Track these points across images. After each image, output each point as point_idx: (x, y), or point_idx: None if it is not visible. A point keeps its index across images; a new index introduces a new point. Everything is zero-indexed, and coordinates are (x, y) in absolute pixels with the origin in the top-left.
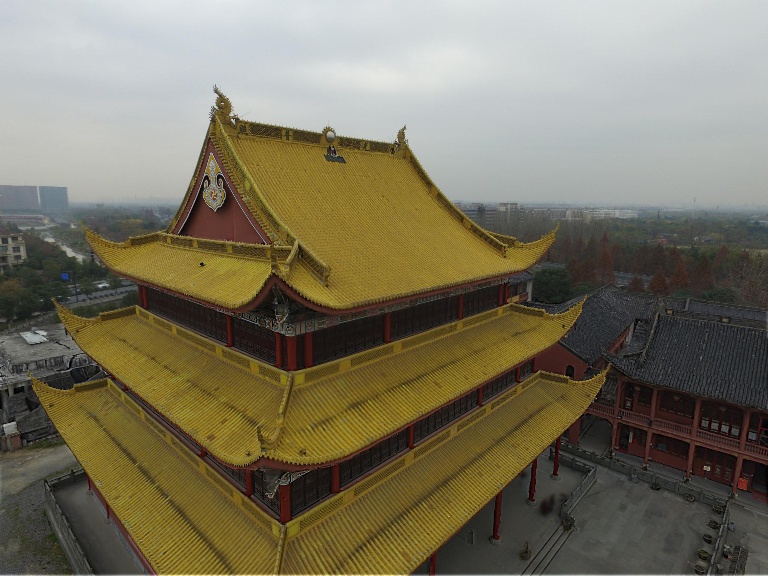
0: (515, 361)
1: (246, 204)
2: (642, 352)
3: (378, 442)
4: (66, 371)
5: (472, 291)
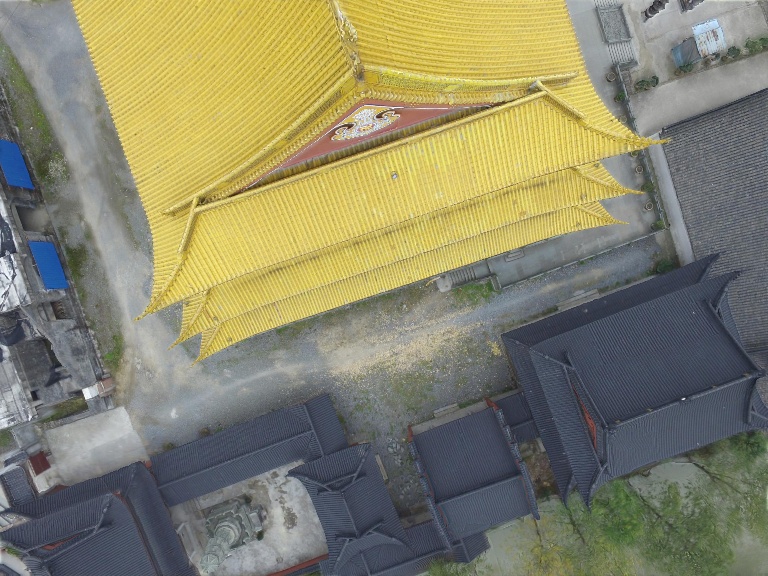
0: None
1: (457, 103)
2: None
3: None
4: (7, 351)
5: None
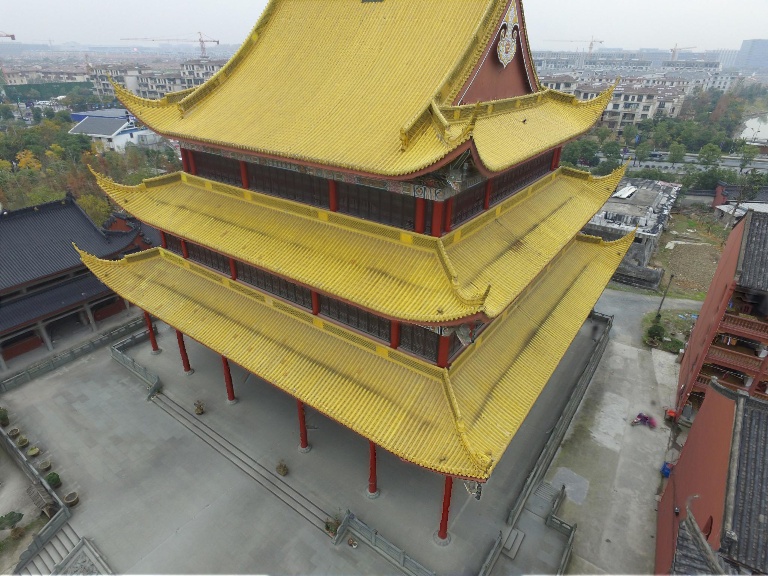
0: (301, 277)
1: None
2: None
3: (161, 230)
4: None
5: (346, 182)
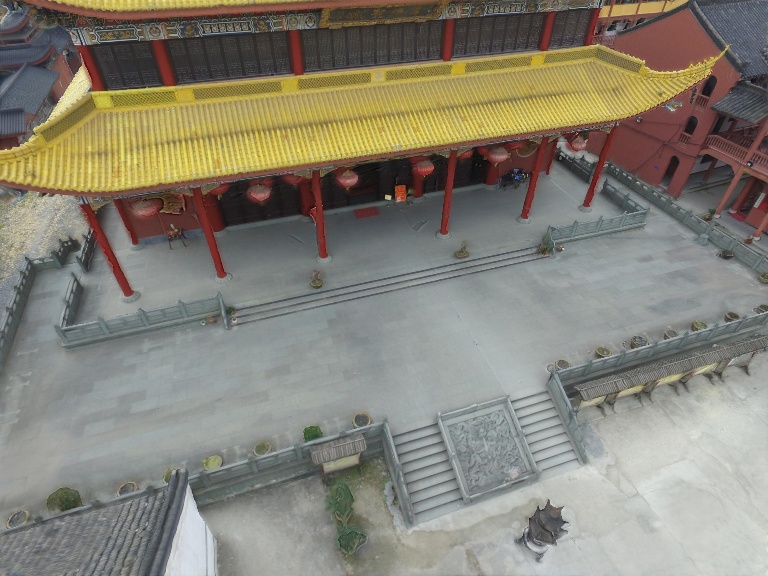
0: None
1: None
2: None
3: (171, 16)
4: None
5: None
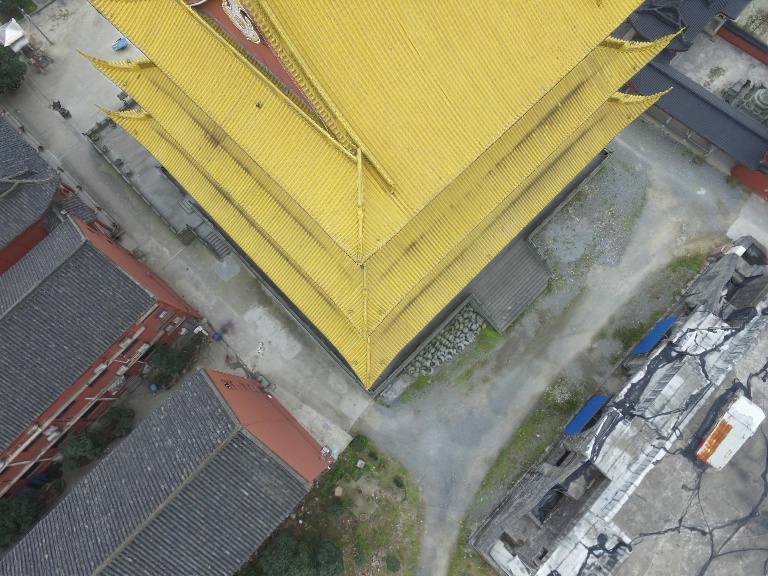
0: None
1: None
2: (8, 179)
3: None
4: (760, 305)
5: None
